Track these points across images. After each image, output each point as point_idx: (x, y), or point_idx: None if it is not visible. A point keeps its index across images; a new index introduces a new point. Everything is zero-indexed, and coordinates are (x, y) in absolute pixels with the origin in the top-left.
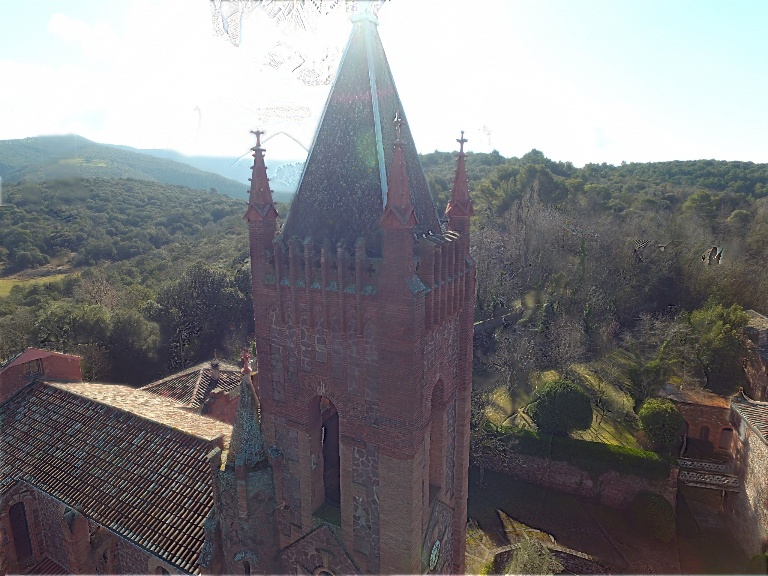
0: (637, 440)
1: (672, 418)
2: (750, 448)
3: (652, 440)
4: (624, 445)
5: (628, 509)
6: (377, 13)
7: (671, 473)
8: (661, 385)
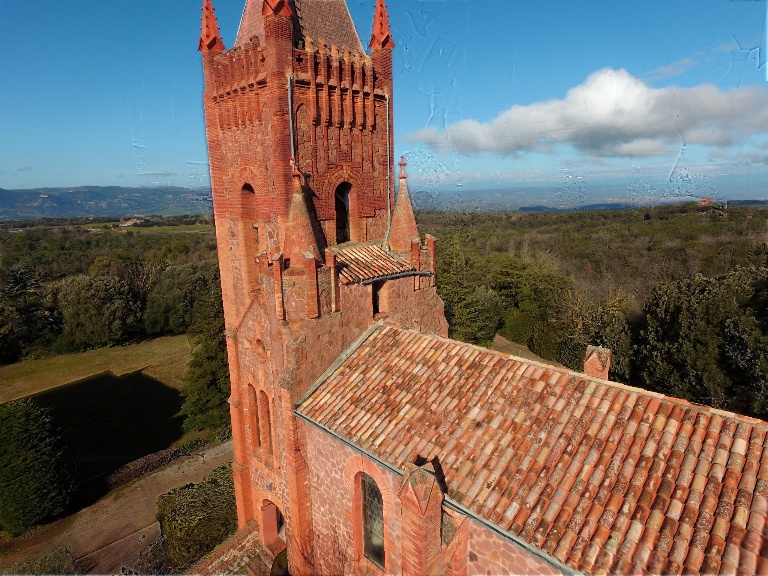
0: None
1: None
2: None
3: None
4: None
5: None
6: None
7: None
8: None
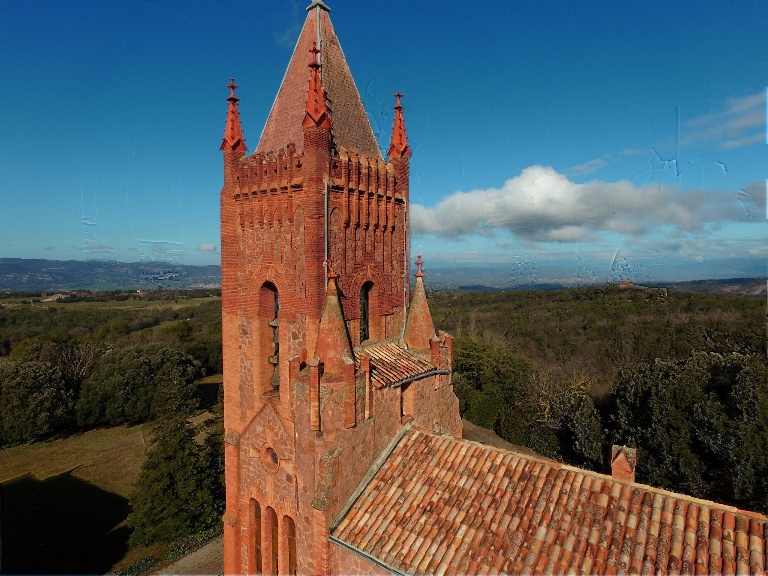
0: None
1: None
2: None
3: None
4: None
5: None
6: (309, 3)
7: None
8: None
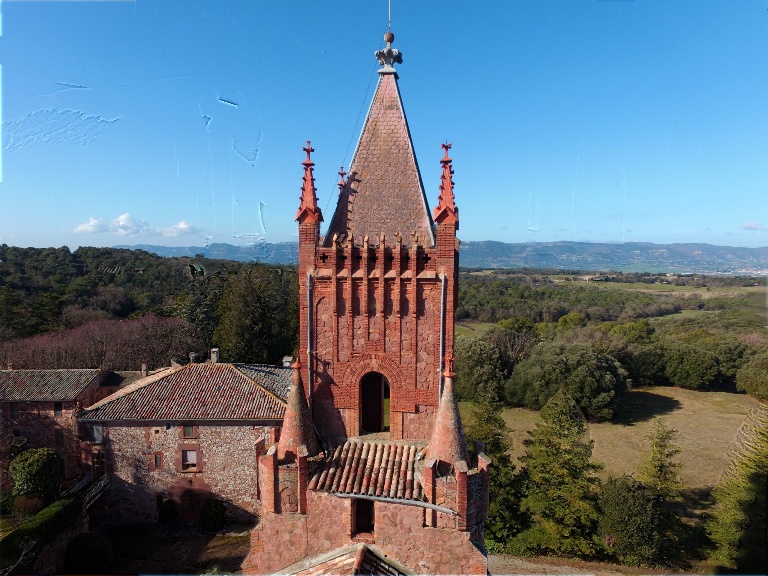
0: (24, 508)
1: (58, 457)
2: (114, 442)
3: (43, 494)
4: (2, 530)
5: (65, 573)
6: None
7: (83, 504)
8: (1, 444)
